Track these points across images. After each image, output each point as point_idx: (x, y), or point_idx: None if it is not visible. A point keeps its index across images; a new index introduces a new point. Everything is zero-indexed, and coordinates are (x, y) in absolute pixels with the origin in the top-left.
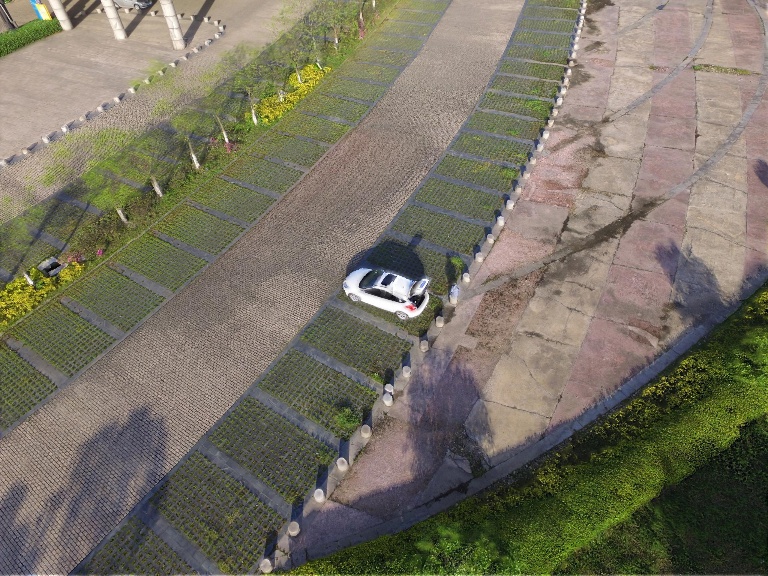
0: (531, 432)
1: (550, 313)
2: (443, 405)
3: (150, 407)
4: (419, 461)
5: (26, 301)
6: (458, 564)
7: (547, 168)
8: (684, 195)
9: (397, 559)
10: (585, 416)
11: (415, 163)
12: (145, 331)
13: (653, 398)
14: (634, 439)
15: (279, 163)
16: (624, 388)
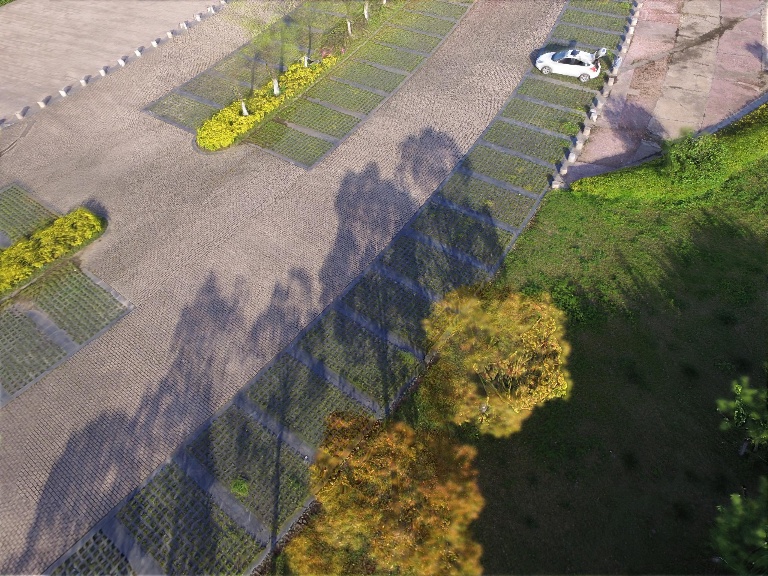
0: (691, 130)
1: (683, 77)
2: (630, 120)
3: (433, 127)
4: (626, 144)
5: (310, 75)
6: (697, 140)
7: (652, 2)
8: (757, 16)
9: (639, 170)
10: (723, 122)
11: (551, 1)
12: (403, 93)
13: (766, 109)
14: (761, 124)
15: (445, 2)
16: (744, 110)
